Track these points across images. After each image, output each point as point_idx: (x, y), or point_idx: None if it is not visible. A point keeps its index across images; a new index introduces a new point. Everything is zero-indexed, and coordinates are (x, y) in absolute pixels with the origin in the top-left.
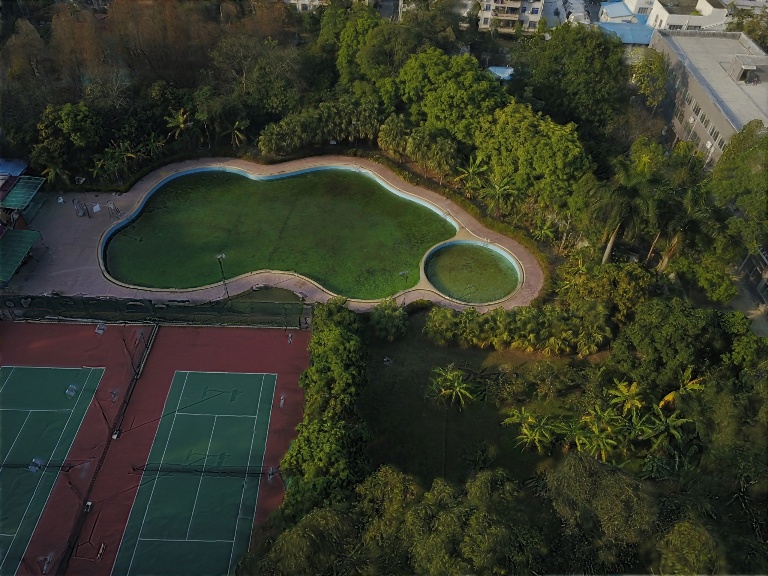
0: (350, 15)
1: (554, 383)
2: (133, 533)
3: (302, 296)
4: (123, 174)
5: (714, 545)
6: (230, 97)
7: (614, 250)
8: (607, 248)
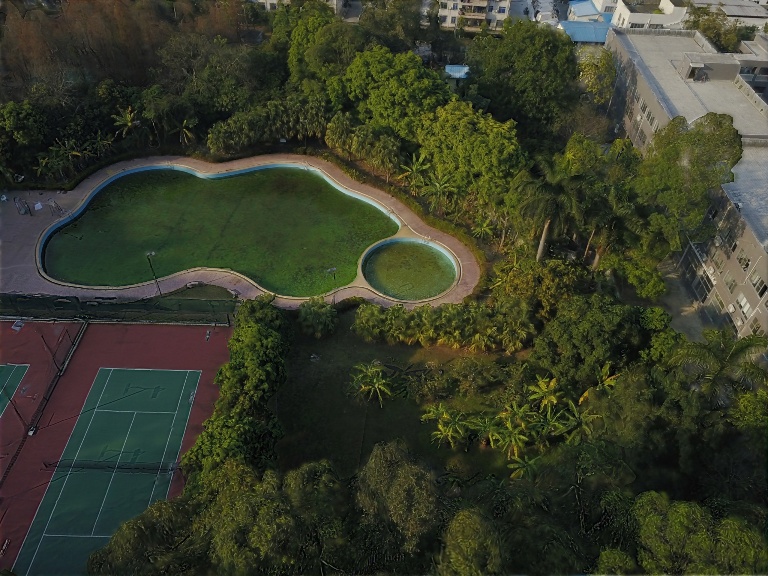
0: (302, 13)
1: (476, 379)
2: (39, 529)
3: (235, 293)
4: (68, 172)
5: (491, 534)
6: (179, 95)
7: (552, 247)
8: (540, 245)
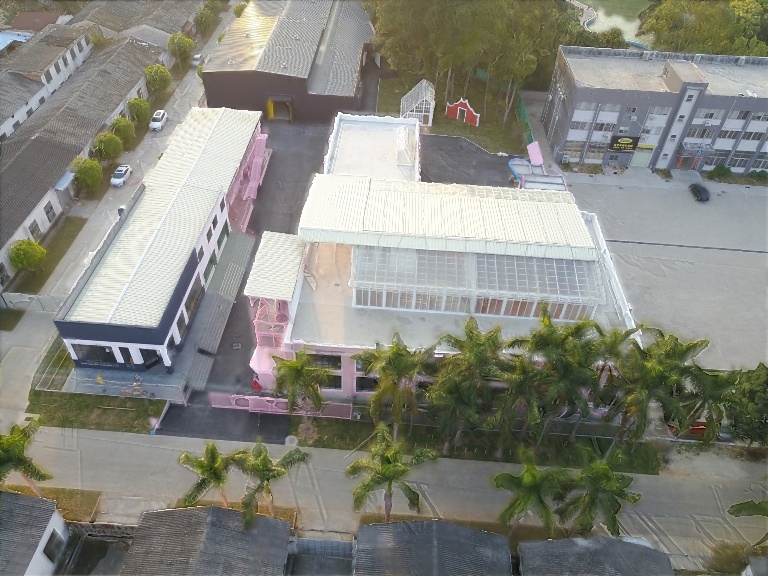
0: None
1: None
2: None
3: (580, 15)
4: None
5: None
6: None
7: None
8: None
